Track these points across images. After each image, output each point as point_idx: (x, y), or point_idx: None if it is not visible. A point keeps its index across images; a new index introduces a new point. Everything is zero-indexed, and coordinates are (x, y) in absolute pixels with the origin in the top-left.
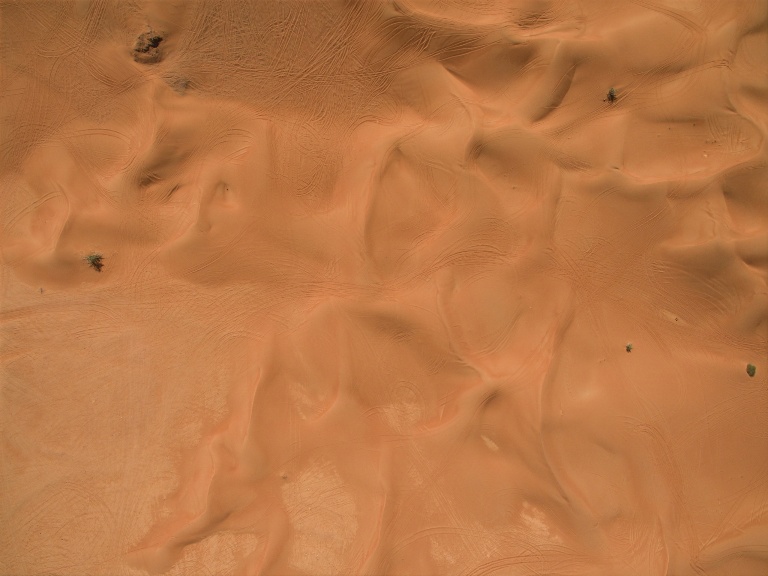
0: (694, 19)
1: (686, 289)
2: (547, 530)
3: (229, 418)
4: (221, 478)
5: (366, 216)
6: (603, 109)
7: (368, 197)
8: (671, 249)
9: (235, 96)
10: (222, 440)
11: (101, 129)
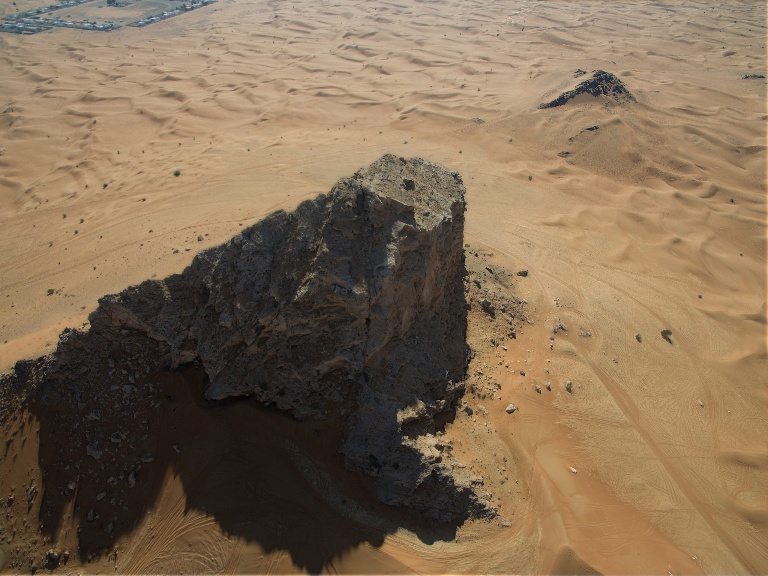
0: None
1: None
2: (701, 282)
3: (568, 213)
4: None
5: None
6: (729, 203)
7: None
8: None
9: None
10: None
11: None
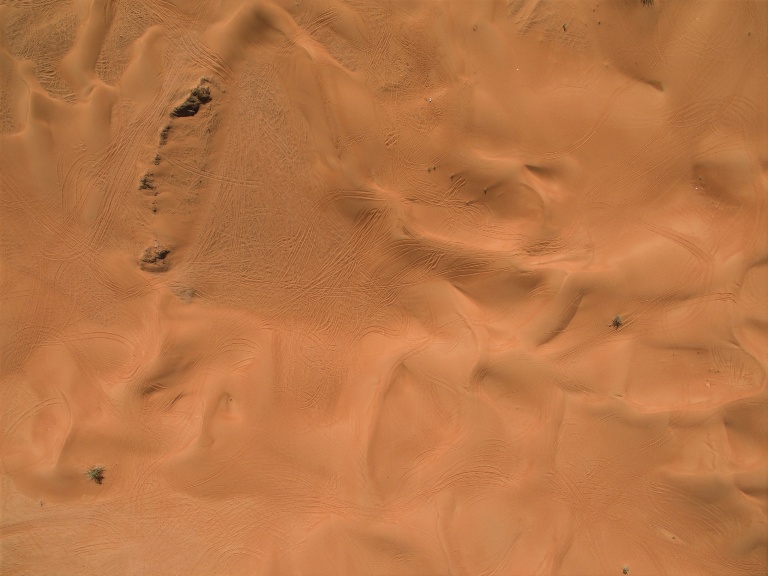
0: (702, 246)
1: (684, 510)
2: None
3: None
4: None
5: (369, 437)
6: (608, 333)
7: (372, 416)
8: (671, 474)
9: (241, 305)
10: None
11: (105, 333)
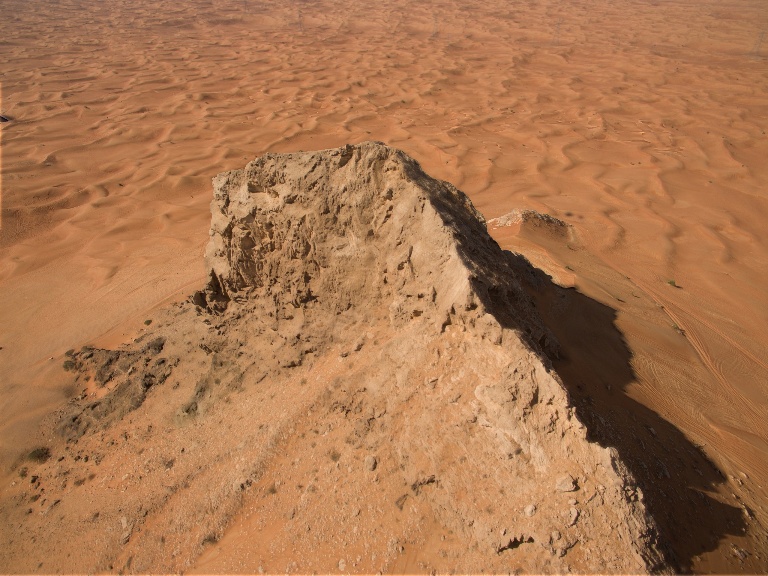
0: None
1: (192, 188)
2: None
3: None
4: None
5: None
6: (122, 187)
7: (74, 227)
8: (176, 186)
9: None
10: None
11: None
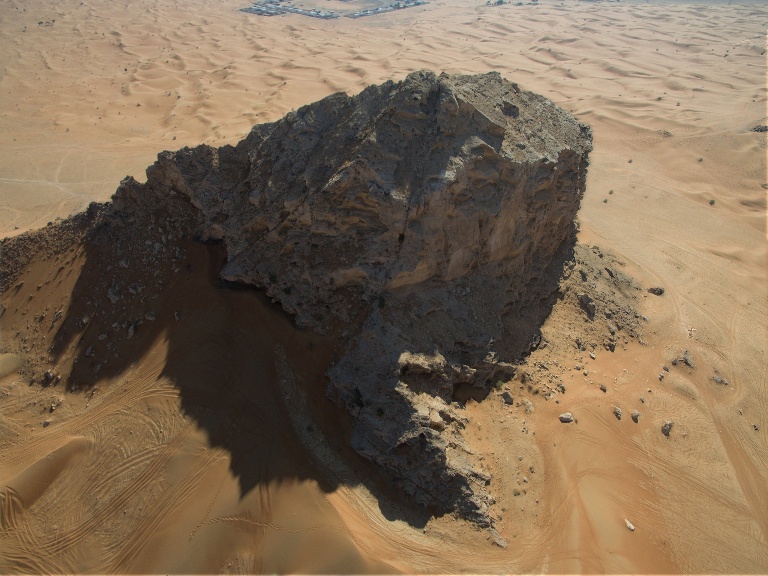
0: None
1: None
2: None
3: None
4: (743, 253)
5: None
6: None
7: None
8: None
9: None
10: None
11: (731, 191)
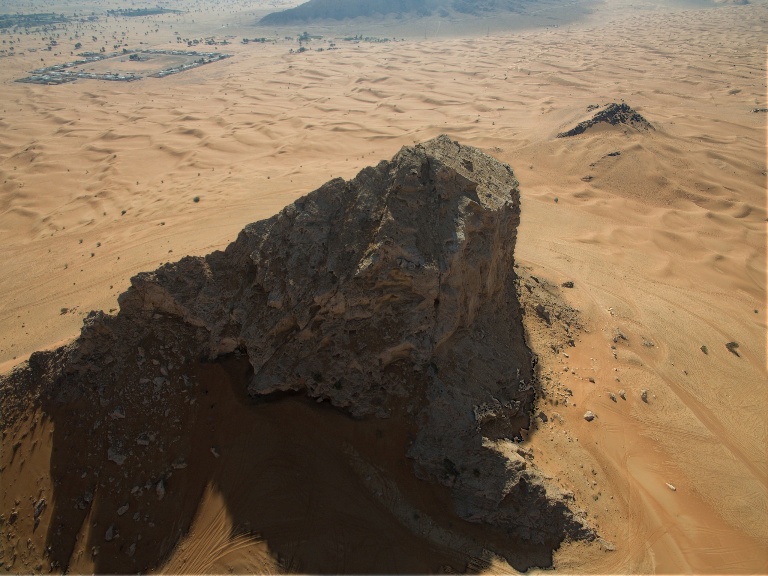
0: None
1: None
2: (753, 297)
3: (601, 232)
4: (598, 236)
5: None
6: (765, 222)
7: None
8: None
9: None
10: (598, 233)
11: None
